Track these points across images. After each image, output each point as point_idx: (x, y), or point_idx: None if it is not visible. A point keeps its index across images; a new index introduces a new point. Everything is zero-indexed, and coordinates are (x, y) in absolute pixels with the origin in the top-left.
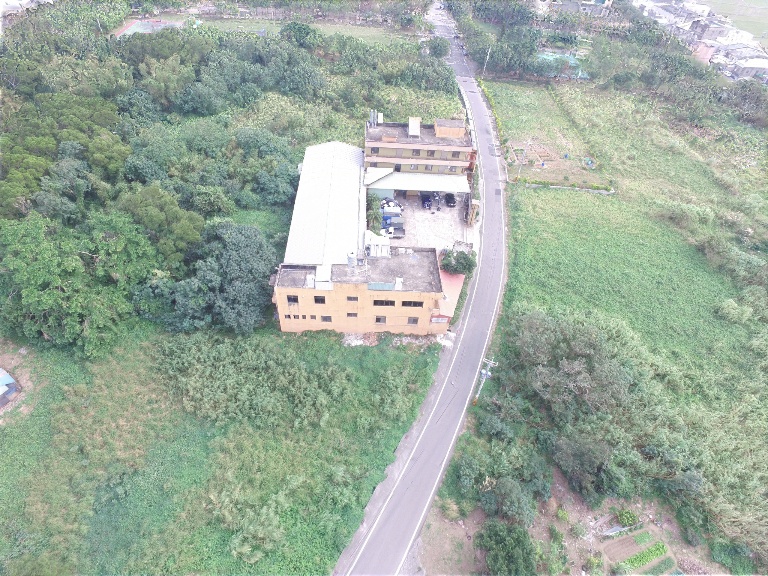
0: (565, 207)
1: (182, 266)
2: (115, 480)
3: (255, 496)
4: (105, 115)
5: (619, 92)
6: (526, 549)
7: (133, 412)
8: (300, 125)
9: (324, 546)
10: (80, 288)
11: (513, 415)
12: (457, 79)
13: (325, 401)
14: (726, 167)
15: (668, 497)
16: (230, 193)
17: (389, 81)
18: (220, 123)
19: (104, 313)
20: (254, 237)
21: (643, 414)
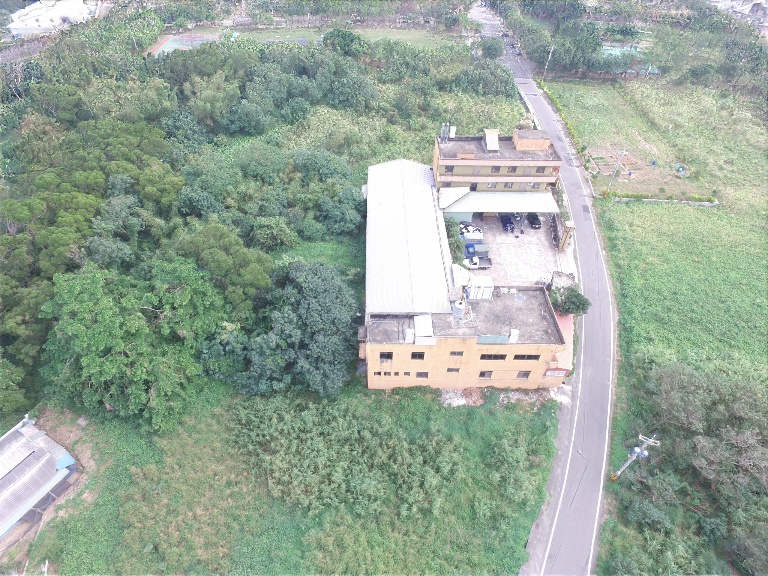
0: (666, 224)
1: (250, 314)
2: None
3: None
4: (154, 143)
5: (695, 87)
6: None
7: (211, 498)
8: (356, 141)
9: None
10: (144, 350)
11: (667, 497)
12: (514, 81)
13: (435, 482)
14: None
15: None
16: (292, 224)
17: (442, 87)
18: (271, 143)
19: (172, 378)
20: (332, 280)
21: None
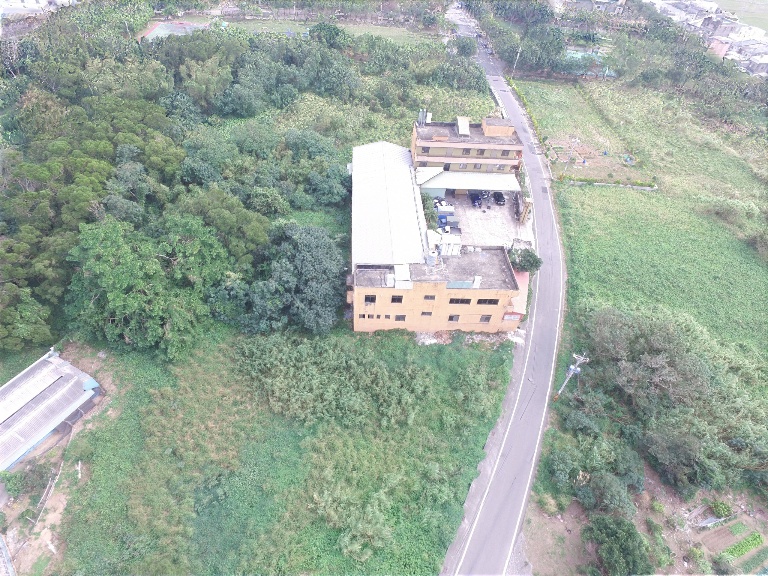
0: (612, 204)
1: (250, 268)
2: (213, 482)
3: (357, 495)
4: (157, 118)
5: (646, 89)
6: (636, 541)
7: (220, 414)
8: (341, 125)
9: (430, 543)
10: None
11: (597, 410)
12: (486, 78)
13: (410, 399)
14: (762, 162)
15: (759, 488)
16: (285, 194)
17: (420, 81)
18: None
19: (184, 316)
20: (324, 238)
21: (724, 407)
